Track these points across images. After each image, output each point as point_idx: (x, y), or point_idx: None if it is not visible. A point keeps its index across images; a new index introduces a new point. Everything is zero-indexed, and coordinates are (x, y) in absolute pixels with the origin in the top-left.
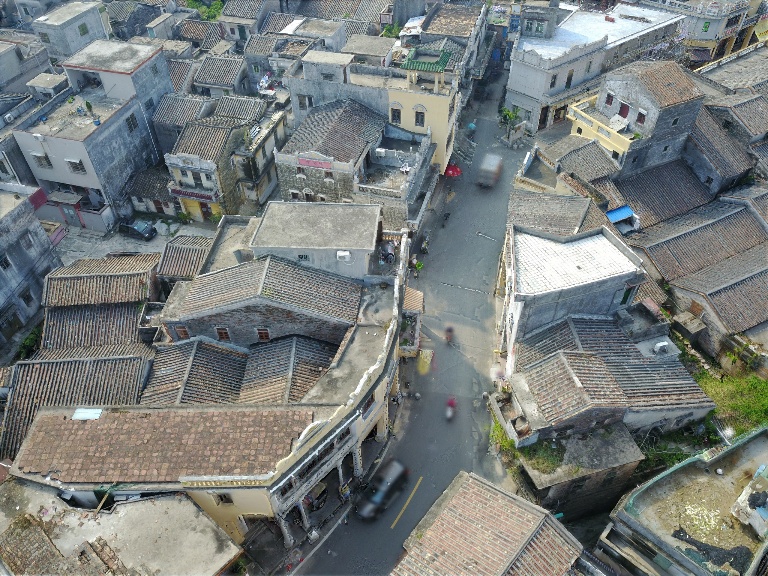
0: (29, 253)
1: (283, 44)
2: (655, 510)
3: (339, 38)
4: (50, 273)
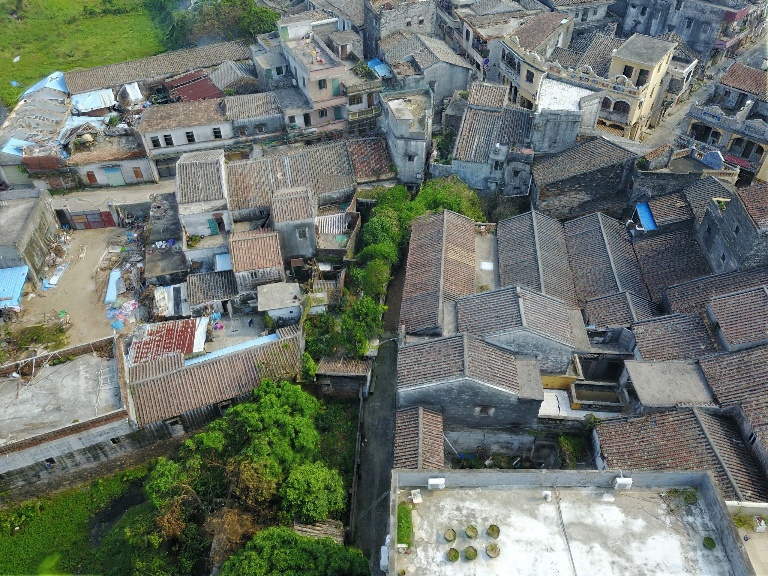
0: (701, 34)
1: None
2: (422, 100)
3: None
4: (675, 33)
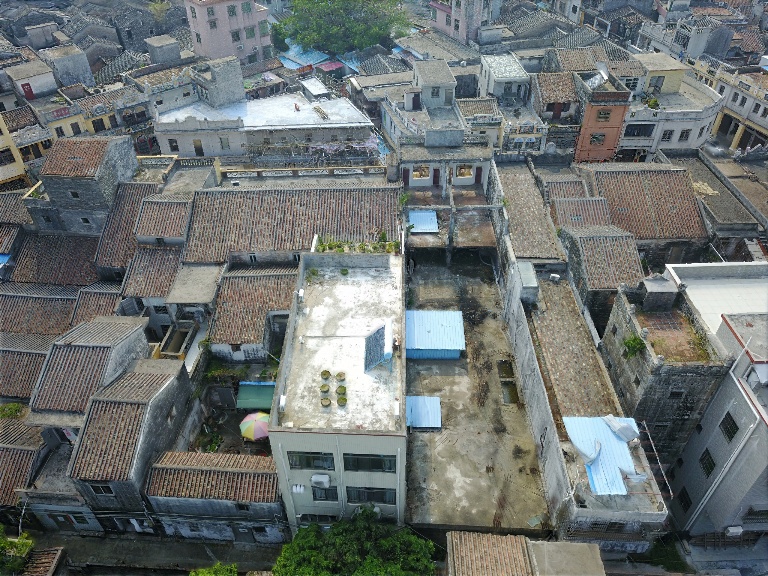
0: None
1: (14, 57)
2: None
3: (72, 64)
4: None
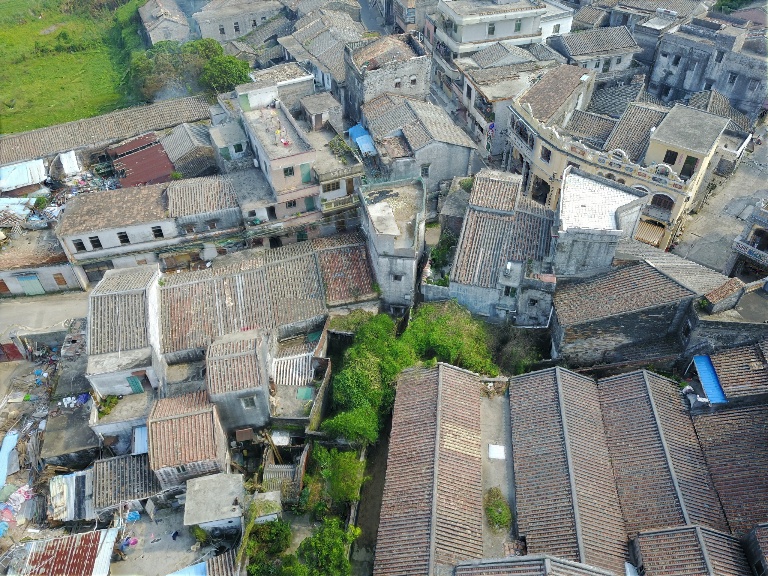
0: (748, 92)
1: None
2: (413, 194)
3: None
4: None
